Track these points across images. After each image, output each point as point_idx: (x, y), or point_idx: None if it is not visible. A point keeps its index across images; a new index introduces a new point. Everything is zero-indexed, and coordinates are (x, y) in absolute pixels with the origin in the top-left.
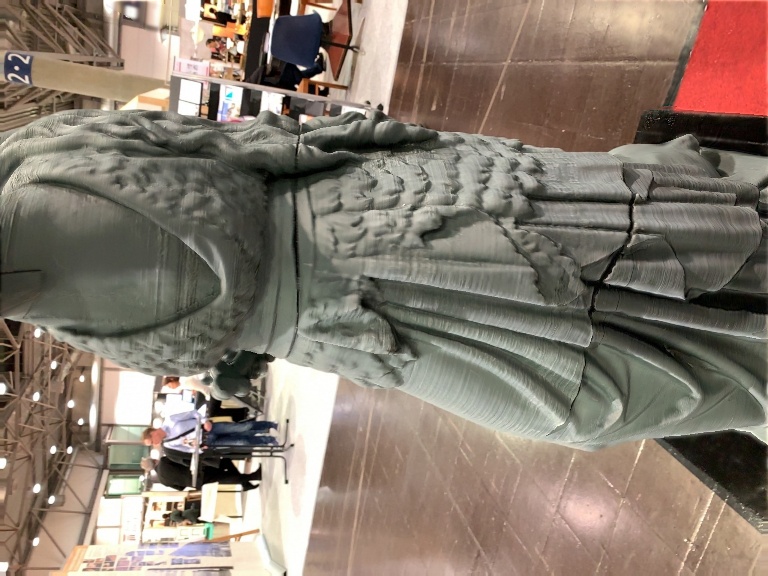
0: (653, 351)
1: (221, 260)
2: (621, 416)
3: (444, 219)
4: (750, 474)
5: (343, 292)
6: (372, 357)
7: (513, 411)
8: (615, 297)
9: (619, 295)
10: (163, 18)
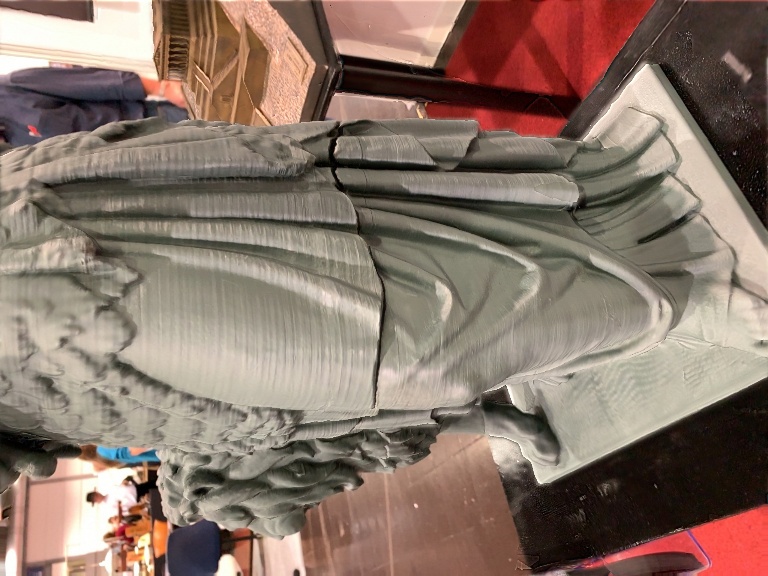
0: (444, 227)
1: None
2: (455, 302)
3: (127, 126)
4: (745, 457)
5: (9, 203)
6: (71, 284)
7: (306, 324)
8: (358, 171)
9: (362, 170)
10: (8, 502)
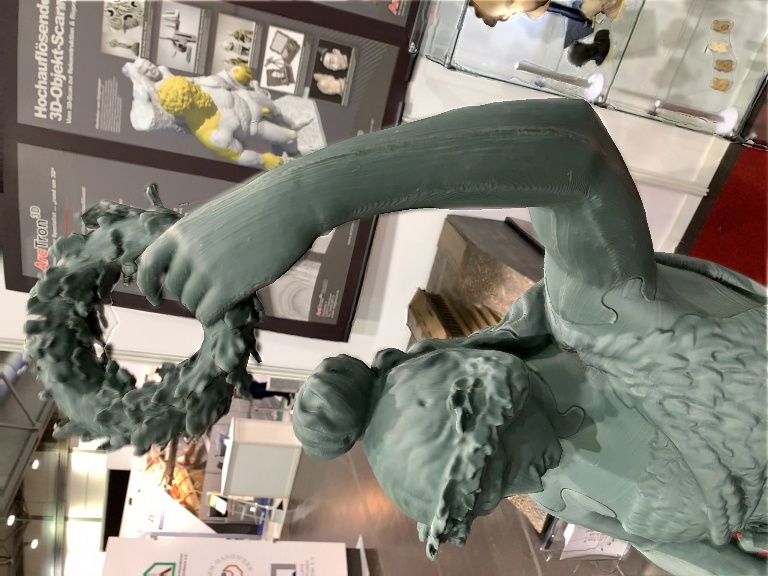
0: None
1: (748, 278)
2: None
3: None
4: None
5: None
6: None
7: None
8: None
9: None
10: None
